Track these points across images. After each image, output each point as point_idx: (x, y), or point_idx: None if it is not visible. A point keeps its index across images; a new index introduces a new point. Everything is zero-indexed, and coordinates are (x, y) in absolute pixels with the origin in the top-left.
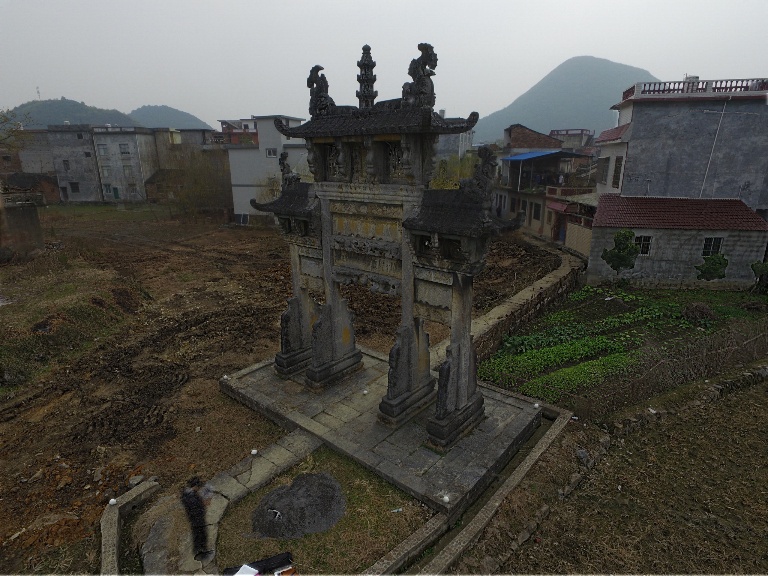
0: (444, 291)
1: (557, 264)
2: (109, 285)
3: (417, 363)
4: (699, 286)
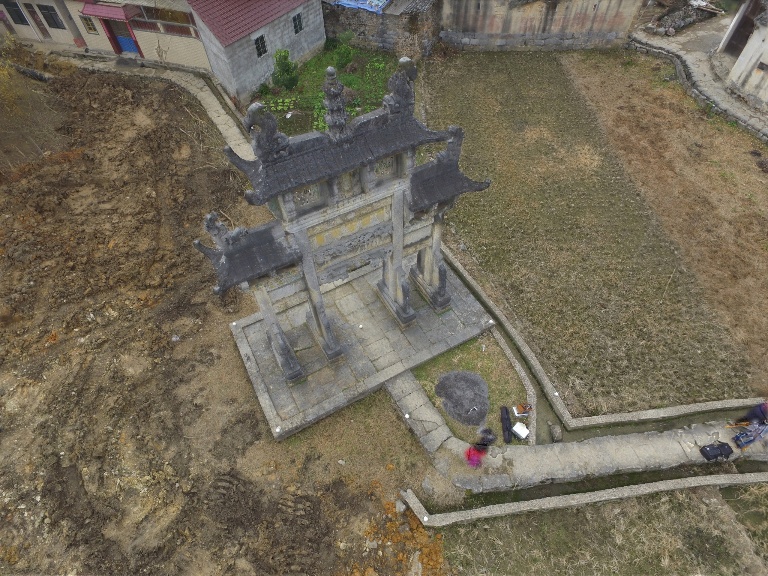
0: (425, 229)
1: (182, 92)
2: None
3: None
4: (302, 61)
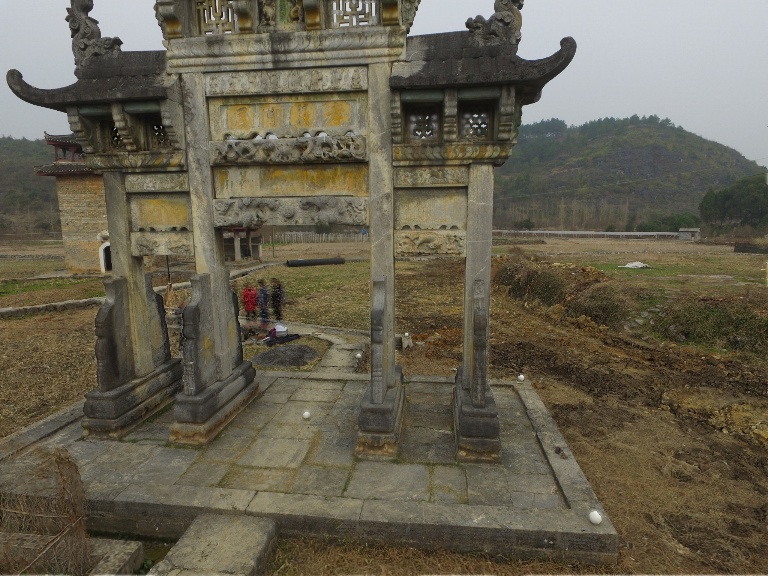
0: (151, 205)
1: None
2: None
3: None
4: None
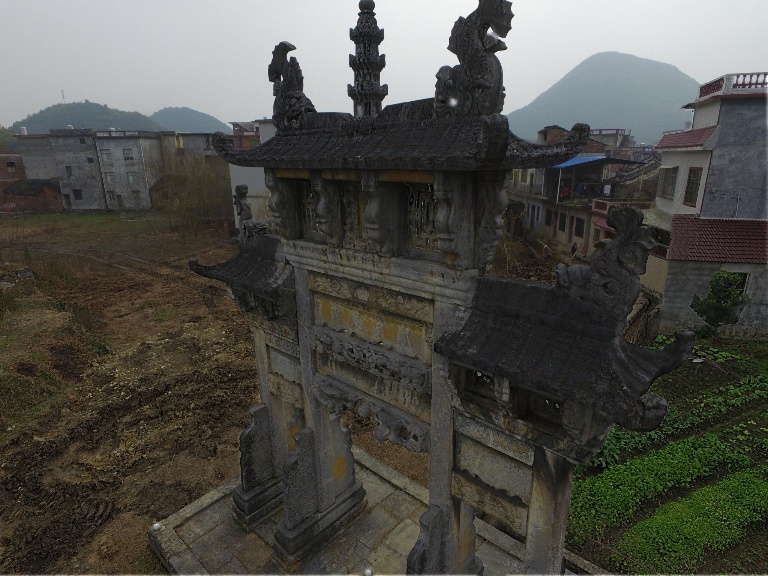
0: (513, 468)
1: None
2: (50, 340)
3: (455, 559)
4: None
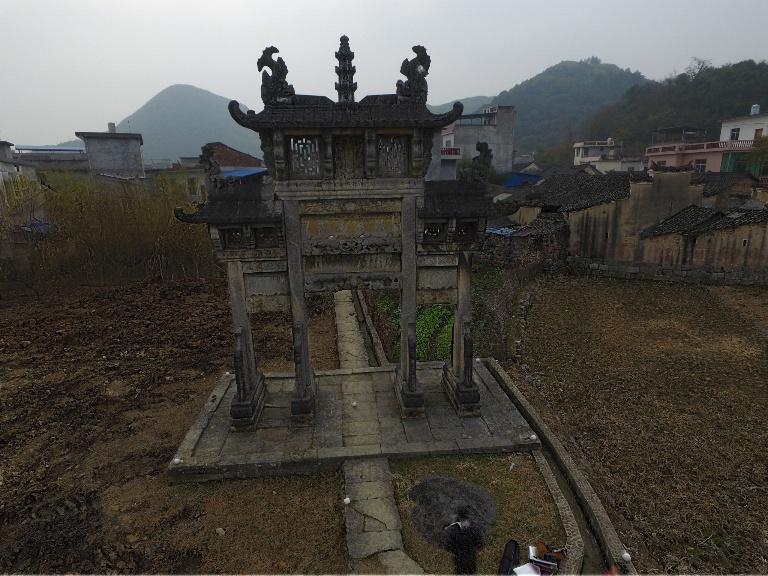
0: (447, 273)
1: None
2: None
3: None
4: None
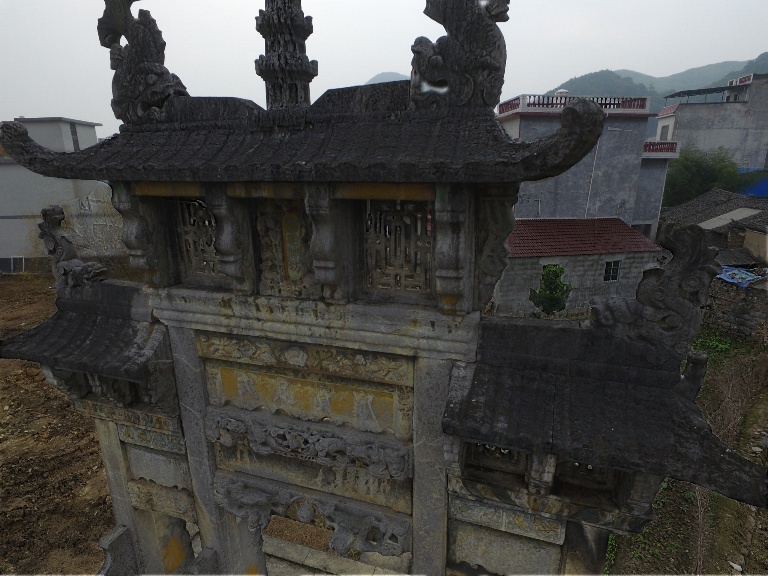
0: (532, 549)
1: None
2: None
3: None
4: None
